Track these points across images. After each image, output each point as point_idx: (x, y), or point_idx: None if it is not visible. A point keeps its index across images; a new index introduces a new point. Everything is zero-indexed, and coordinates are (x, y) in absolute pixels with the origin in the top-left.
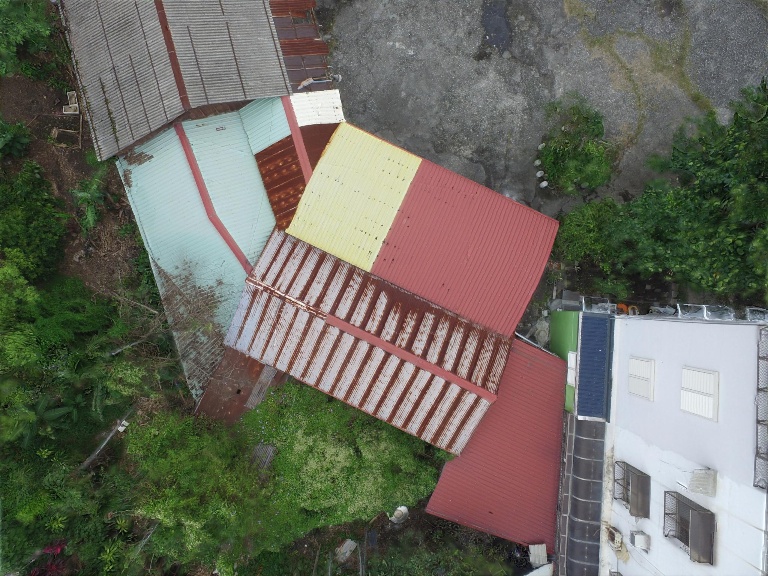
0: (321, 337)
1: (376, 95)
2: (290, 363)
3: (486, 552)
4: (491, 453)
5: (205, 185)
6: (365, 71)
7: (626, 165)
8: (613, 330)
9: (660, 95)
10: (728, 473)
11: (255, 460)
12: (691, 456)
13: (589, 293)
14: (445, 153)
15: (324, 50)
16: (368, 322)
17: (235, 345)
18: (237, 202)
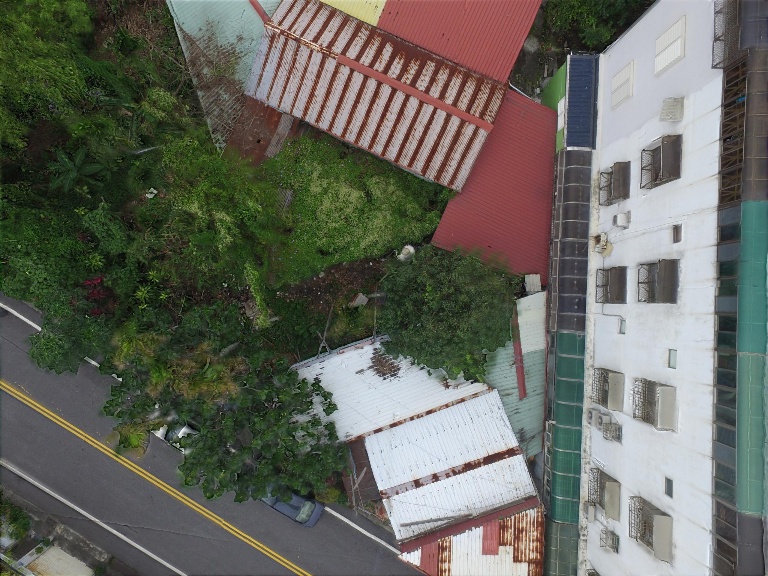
0: (333, 78)
1: None
2: (305, 109)
3: None
4: (489, 193)
5: None
6: None
7: None
8: (598, 67)
9: None
10: (693, 89)
11: (275, 204)
12: None
13: None
14: None
15: None
16: (376, 64)
17: (255, 94)
18: None
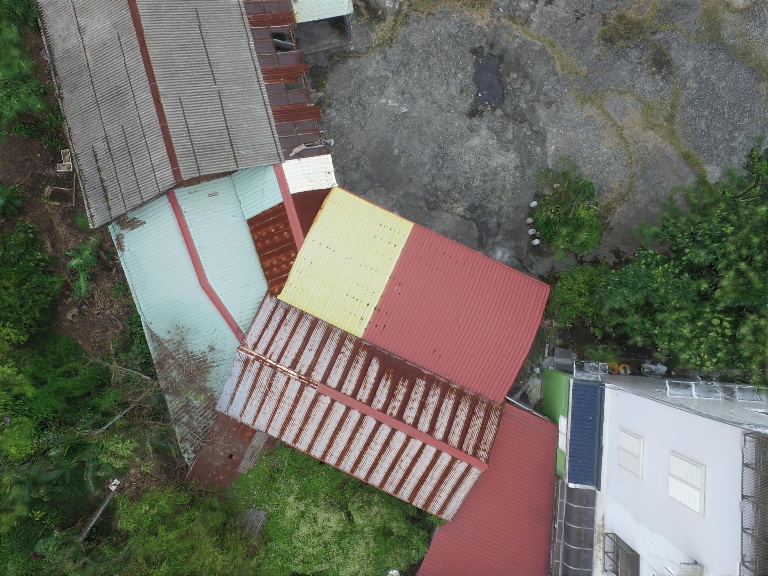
0: (312, 405)
1: (369, 152)
2: (282, 429)
3: None
4: (482, 518)
5: (197, 252)
6: (358, 128)
7: (618, 222)
8: (603, 398)
9: (651, 153)
10: (714, 571)
11: (247, 524)
12: (678, 544)
13: (581, 351)
14: (437, 210)
15: (316, 115)
16: (359, 390)
17: (227, 411)
18: (229, 268)
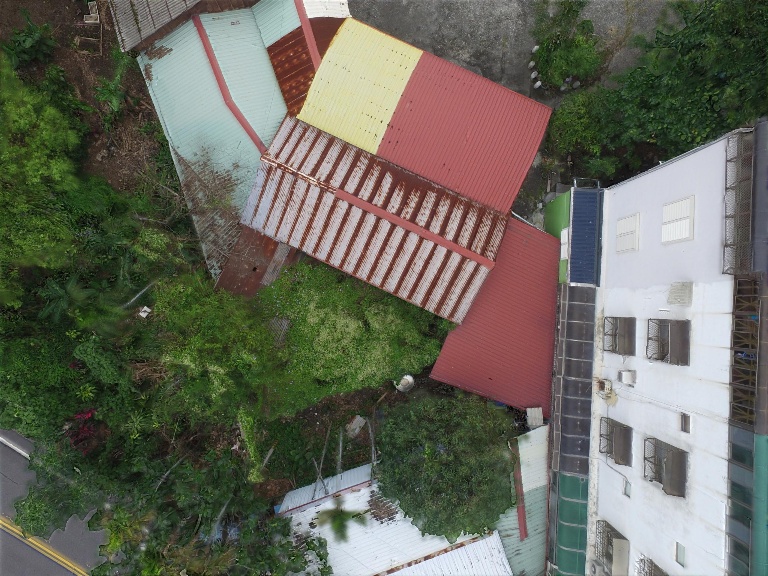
0: (331, 212)
1: (379, 3)
2: (302, 239)
3: None
4: (490, 324)
5: (222, 73)
6: None
7: (615, 67)
8: (602, 202)
9: (647, 0)
10: (702, 279)
11: (270, 333)
12: (671, 280)
13: (581, 186)
14: (445, 57)
15: None
16: (375, 197)
17: (251, 224)
18: (251, 90)
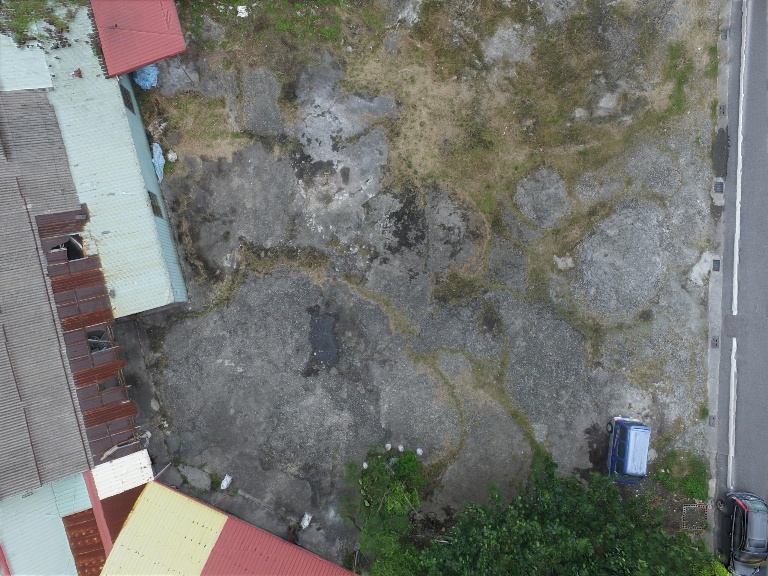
0: None
1: (205, 412)
2: None
3: None
4: None
5: (5, 561)
6: (195, 388)
7: (448, 480)
8: None
9: (481, 411)
10: None
11: None
12: None
13: None
14: (272, 470)
15: (132, 411)
16: None
17: None
18: (40, 572)
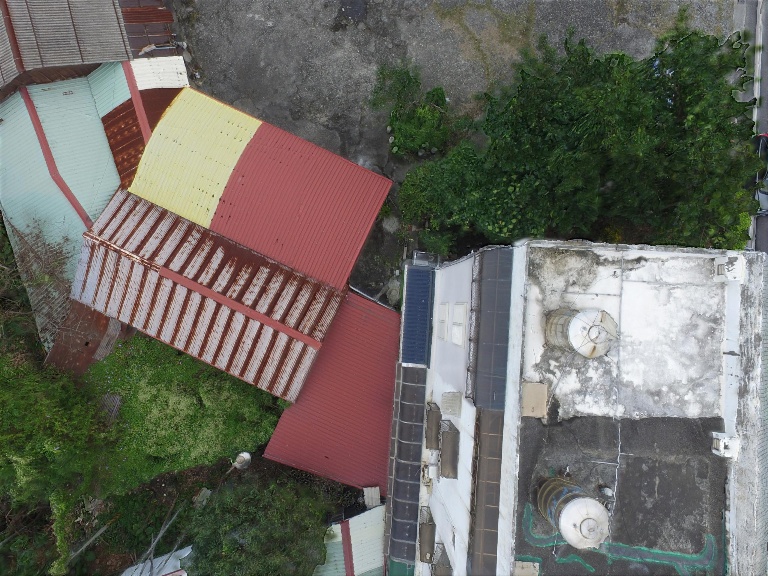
0: (157, 289)
1: (236, 65)
2: (132, 315)
3: (336, 499)
4: (327, 401)
5: (48, 146)
6: (226, 42)
7: (475, 131)
8: (434, 281)
9: (507, 64)
10: None
11: (103, 409)
12: (455, 384)
13: (438, 253)
14: (302, 120)
15: (168, 18)
16: (202, 275)
17: (80, 298)
18: (81, 162)
